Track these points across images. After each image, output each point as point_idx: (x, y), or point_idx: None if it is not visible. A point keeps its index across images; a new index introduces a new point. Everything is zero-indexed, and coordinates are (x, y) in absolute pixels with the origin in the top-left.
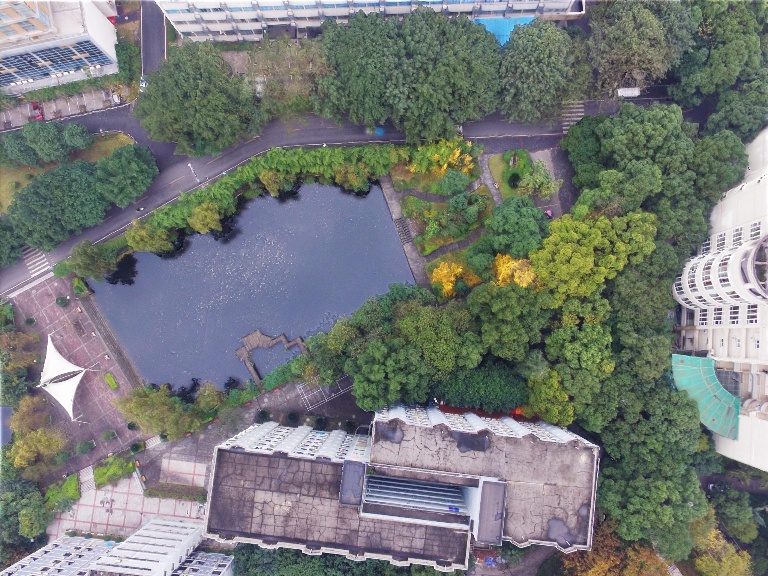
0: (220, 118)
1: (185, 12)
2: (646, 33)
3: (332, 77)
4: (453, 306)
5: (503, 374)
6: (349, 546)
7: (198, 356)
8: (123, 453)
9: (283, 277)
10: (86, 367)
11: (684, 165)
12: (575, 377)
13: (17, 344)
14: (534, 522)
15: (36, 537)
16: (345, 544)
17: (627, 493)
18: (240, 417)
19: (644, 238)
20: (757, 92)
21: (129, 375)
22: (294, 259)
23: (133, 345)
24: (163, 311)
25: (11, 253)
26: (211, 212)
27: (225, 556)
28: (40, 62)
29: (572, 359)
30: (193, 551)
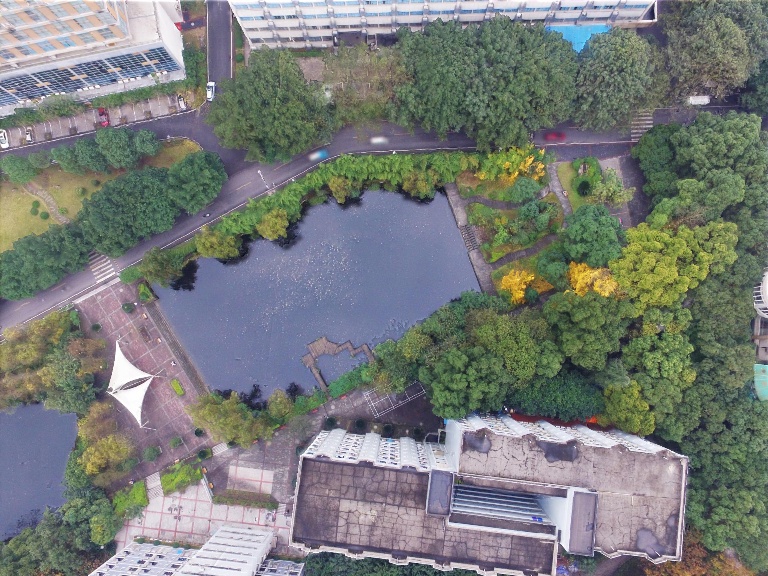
0: (298, 126)
1: (258, 19)
2: (730, 43)
3: (410, 85)
4: (527, 314)
5: (579, 383)
6: (435, 556)
7: (263, 363)
8: (190, 460)
9: (348, 284)
10: (152, 373)
11: (767, 175)
12: (656, 386)
13: (87, 350)
14: (623, 532)
15: (106, 544)
16: (431, 554)
17: (710, 503)
18: (310, 424)
19: (726, 248)
20: None
21: (195, 381)
22: (359, 266)
23: (198, 351)
24: (228, 317)
25: (80, 259)
26: (281, 219)
27: (294, 563)
28: (110, 68)
29: (652, 368)
30: (265, 559)
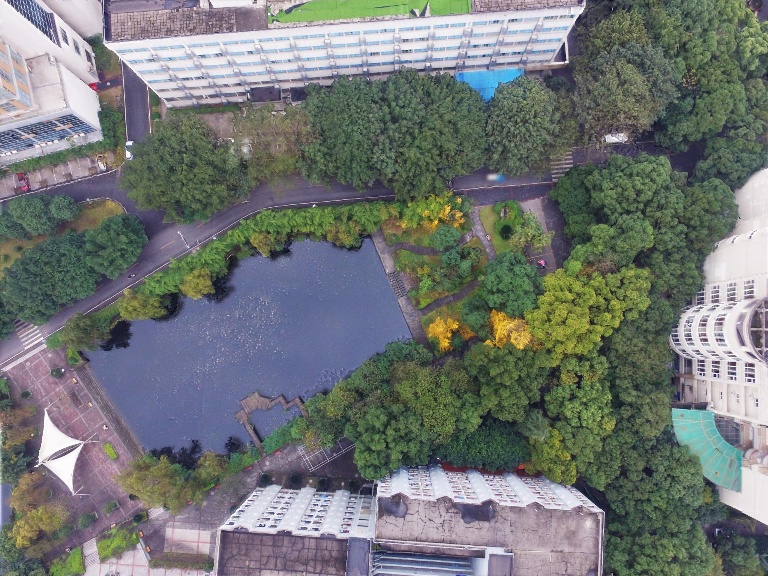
0: (207, 190)
1: (167, 81)
2: (631, 90)
3: (318, 144)
4: (451, 365)
5: (504, 432)
6: None
7: (197, 421)
8: (126, 524)
9: (279, 337)
10: (84, 438)
11: (675, 219)
12: (576, 436)
13: (13, 422)
14: None
15: None
16: None
17: (634, 551)
18: (242, 484)
19: (638, 294)
20: (744, 140)
21: (128, 444)
22: (289, 318)
23: (131, 413)
24: (159, 377)
25: (3, 329)
26: (203, 279)
27: None
28: (23, 135)
29: (572, 417)
30: None
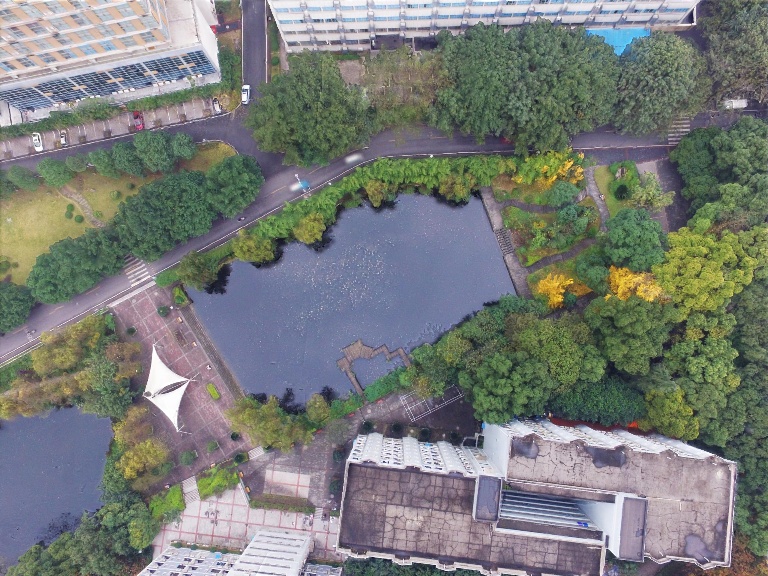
0: (340, 130)
1: (297, 22)
2: None
3: (452, 89)
4: (567, 319)
5: (620, 387)
6: (482, 561)
7: (299, 366)
8: (226, 464)
9: (384, 287)
10: (187, 377)
11: None
12: (699, 391)
13: (125, 355)
14: (671, 538)
15: (144, 548)
16: (478, 559)
17: (755, 508)
18: (347, 428)
19: None
20: None
21: (230, 385)
22: (394, 269)
23: (233, 355)
24: (263, 321)
25: (117, 263)
26: (318, 223)
27: (332, 568)
28: (146, 71)
29: (696, 373)
30: (305, 563)
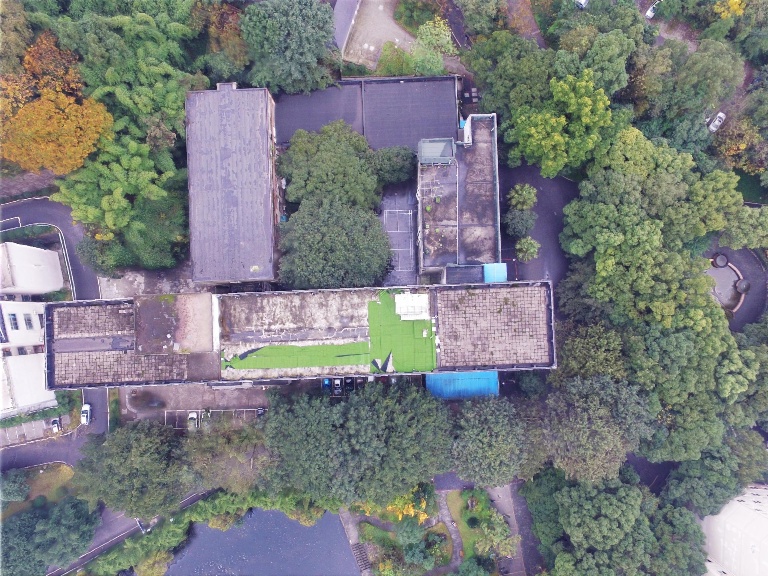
0: None
1: None
2: (601, 445)
3: (275, 467)
4: None
5: None
6: None
7: None
8: None
9: None
10: None
11: (641, 573)
12: None
13: None
14: None
15: None
16: None
17: None
18: None
19: None
20: (718, 474)
21: None
22: None
23: None
24: None
25: None
26: (158, 566)
27: None
28: None
29: None
30: None
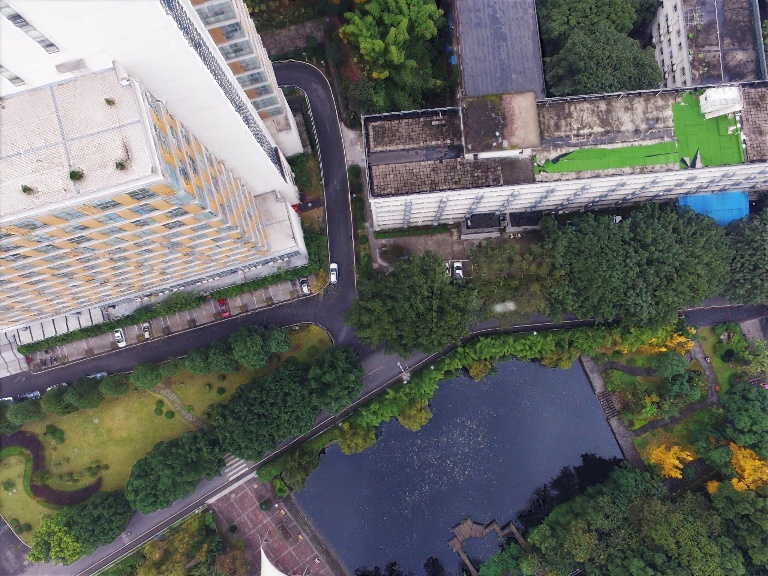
0: (454, 335)
1: (395, 215)
2: None
3: (567, 285)
4: (691, 501)
5: (754, 572)
6: None
7: (409, 550)
8: None
9: (489, 461)
10: (295, 572)
11: None
12: None
13: (237, 567)
14: None
15: None
16: None
17: None
18: None
19: None
20: None
21: None
22: (498, 441)
23: (340, 543)
24: (368, 505)
25: (219, 468)
26: (425, 411)
27: None
28: None
29: None
30: None
